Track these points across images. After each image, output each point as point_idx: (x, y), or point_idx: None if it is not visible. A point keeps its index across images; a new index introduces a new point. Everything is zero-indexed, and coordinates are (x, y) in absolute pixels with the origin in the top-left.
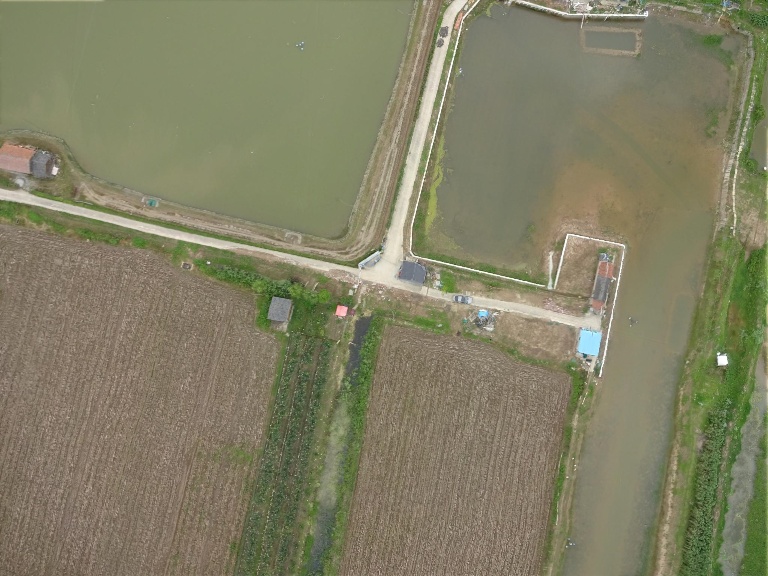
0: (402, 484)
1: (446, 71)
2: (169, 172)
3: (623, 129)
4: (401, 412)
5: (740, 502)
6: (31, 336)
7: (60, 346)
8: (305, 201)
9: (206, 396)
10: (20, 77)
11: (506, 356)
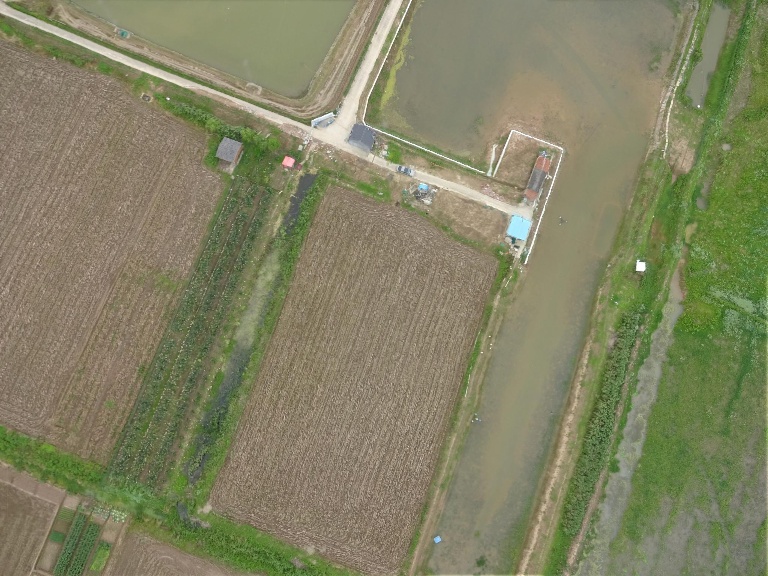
0: (321, 335)
1: None
2: (146, 11)
3: (575, 50)
4: (331, 267)
5: (643, 403)
6: None
7: (6, 151)
8: (271, 60)
9: (142, 221)
10: None
11: (439, 232)
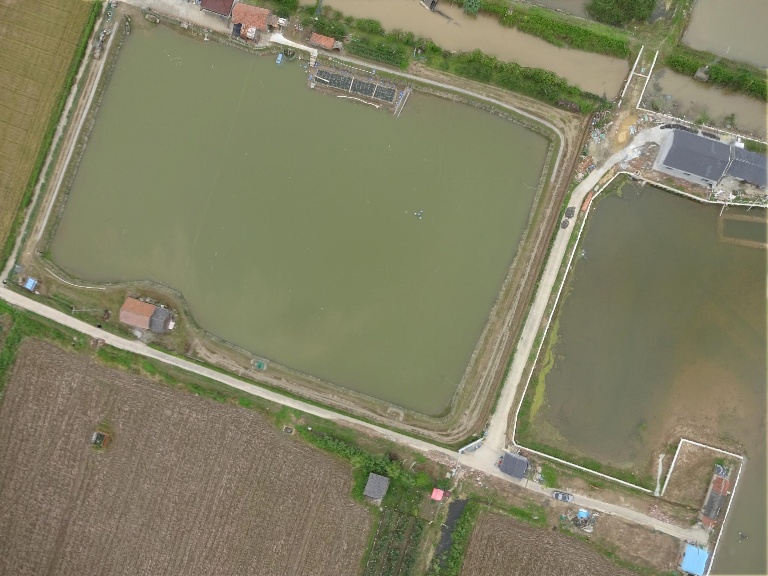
0: None
1: (568, 254)
2: (279, 334)
3: (755, 329)
4: None
5: None
6: (138, 482)
7: (164, 494)
8: (410, 375)
9: (297, 560)
10: (145, 228)
11: (602, 558)
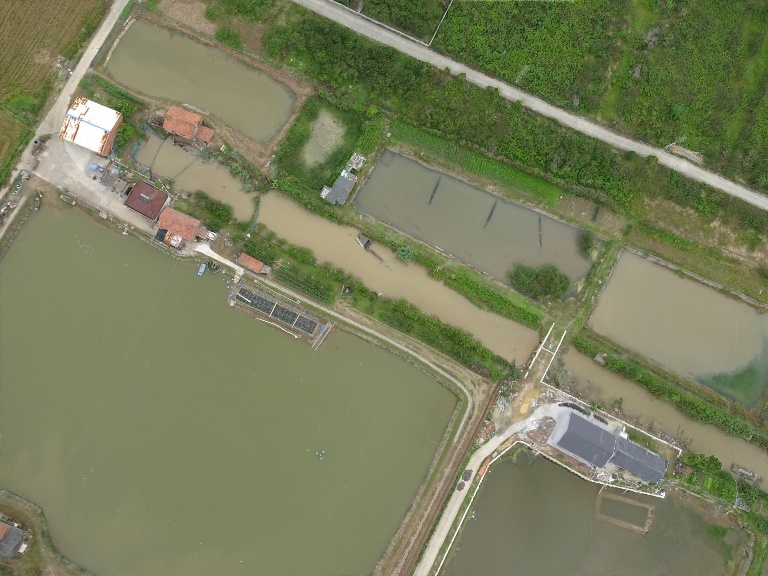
0: None
1: (459, 517)
2: (147, 568)
3: None
4: None
5: None
6: None
7: None
8: None
9: None
10: (13, 431)
11: None
